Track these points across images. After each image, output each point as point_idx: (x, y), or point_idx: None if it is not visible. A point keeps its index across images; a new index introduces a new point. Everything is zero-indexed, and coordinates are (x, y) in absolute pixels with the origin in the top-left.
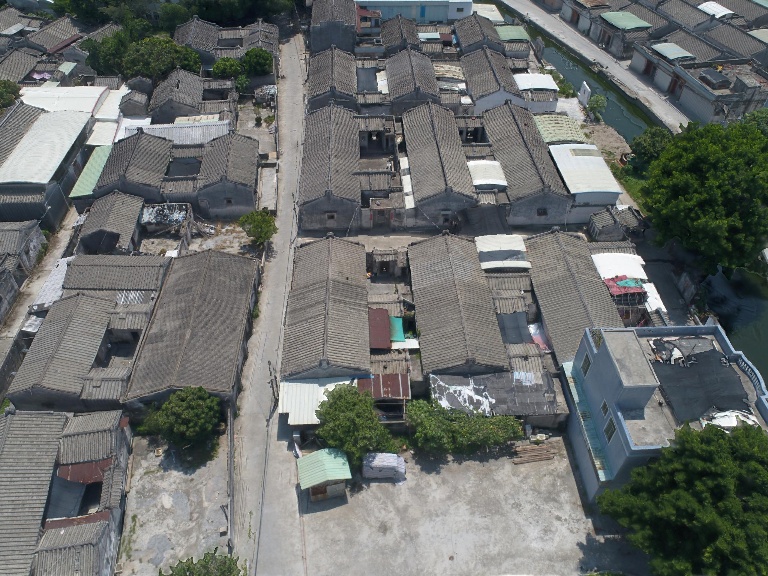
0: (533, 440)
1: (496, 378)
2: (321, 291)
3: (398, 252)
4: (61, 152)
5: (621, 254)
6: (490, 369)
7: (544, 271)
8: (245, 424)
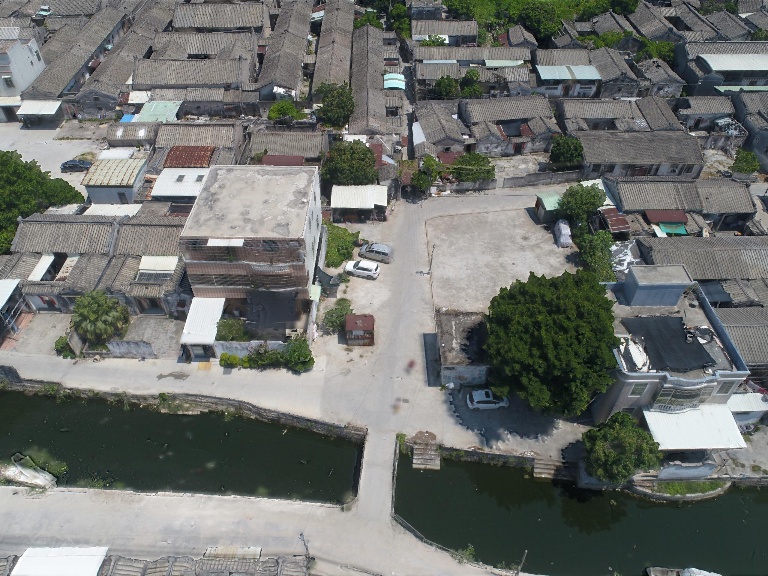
0: None
1: None
2: None
3: None
4: (749, 68)
5: None
6: None
7: None
8: None
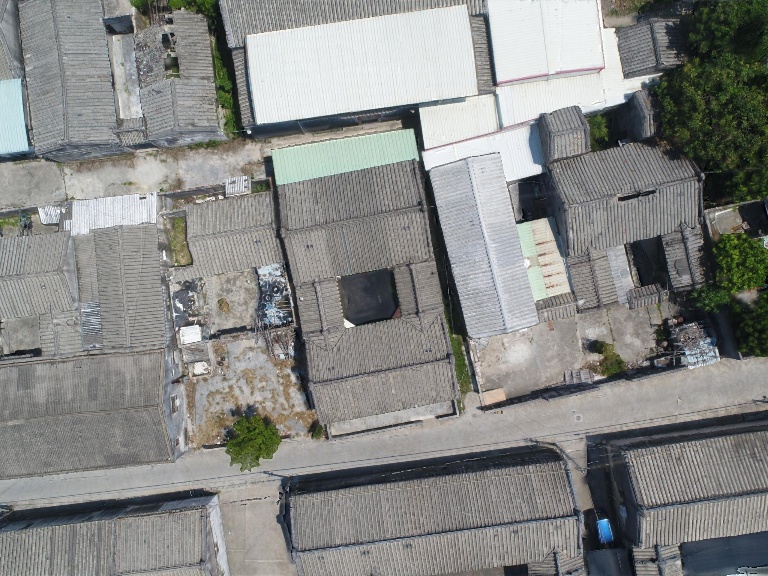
0: None
1: None
2: (91, 571)
3: None
4: (343, 103)
5: None
6: None
7: None
8: None
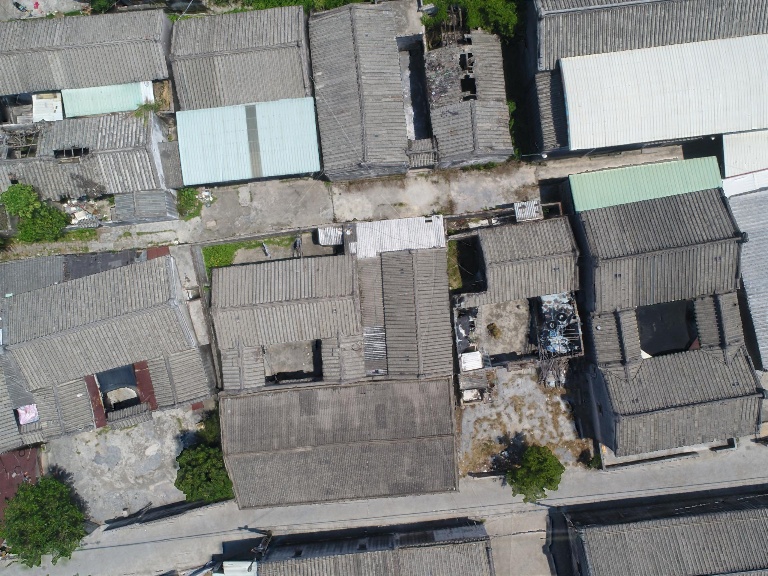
0: None
1: None
2: None
3: None
4: (661, 130)
5: None
6: None
7: None
8: None
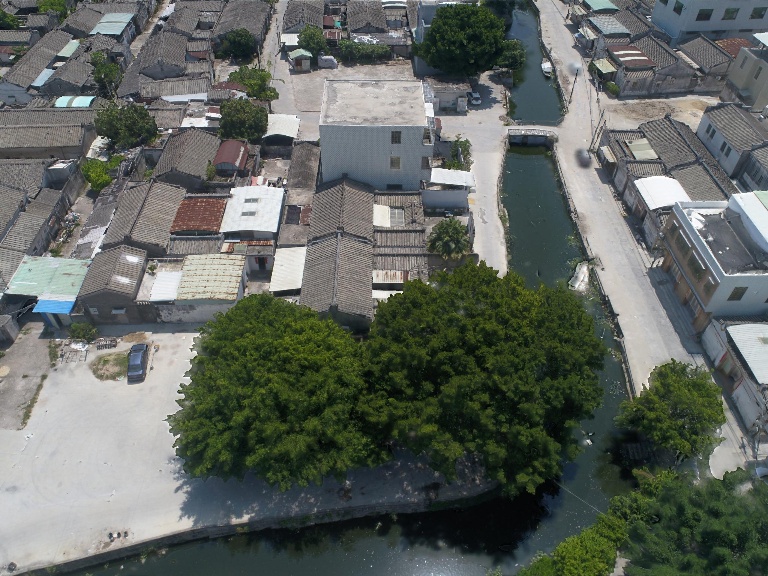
0: (397, 59)
1: (381, 34)
2: (301, 7)
3: (342, 6)
4: None
5: (454, 2)
6: (378, 31)
7: (413, 6)
8: (265, 56)
